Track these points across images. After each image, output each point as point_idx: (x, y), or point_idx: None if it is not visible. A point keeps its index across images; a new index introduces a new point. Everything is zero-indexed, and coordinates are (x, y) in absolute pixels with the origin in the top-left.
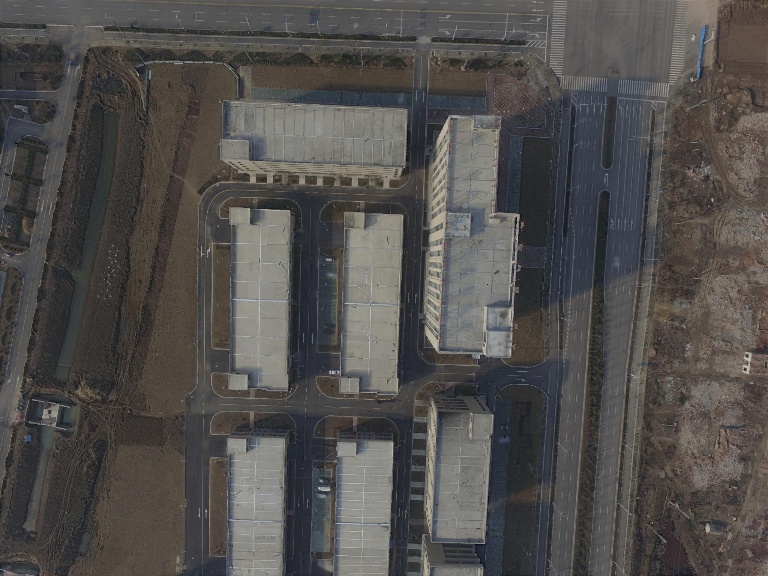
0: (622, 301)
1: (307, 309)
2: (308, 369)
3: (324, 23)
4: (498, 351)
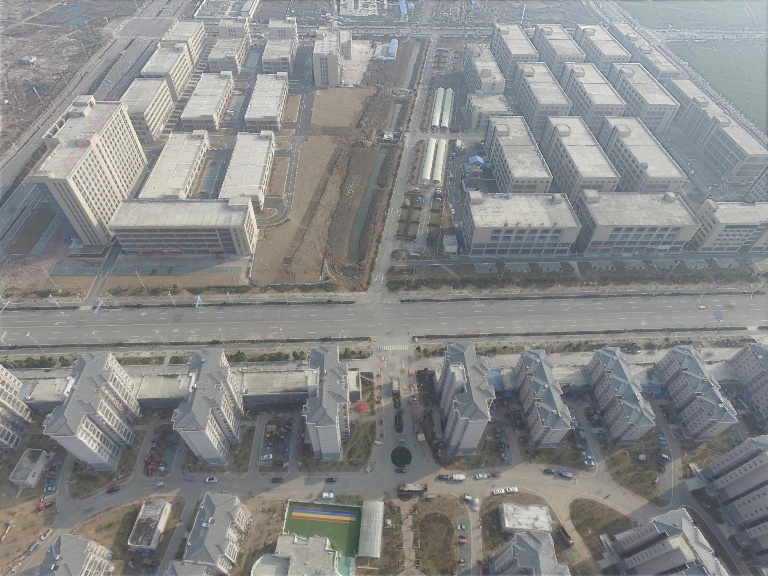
0: (2, 180)
1: (225, 173)
2: (230, 151)
3: (170, 314)
4: (85, 97)
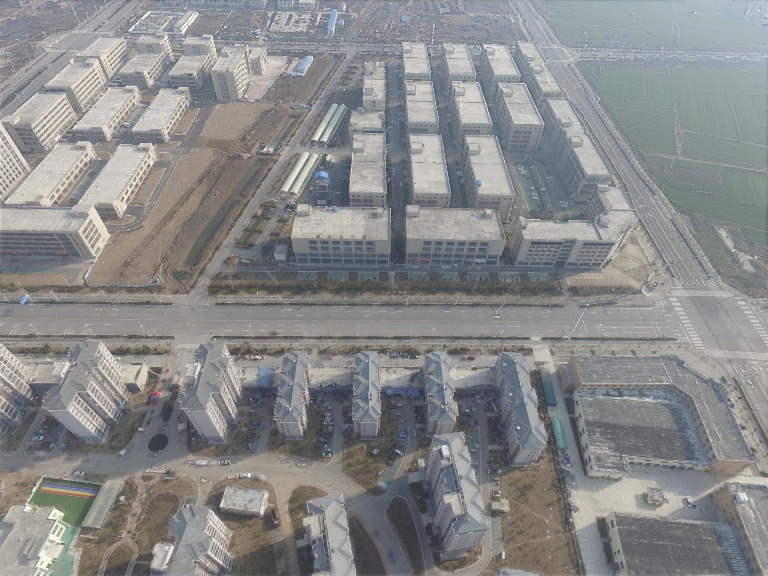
0: None
1: None
2: None
3: (2, 310)
4: None
